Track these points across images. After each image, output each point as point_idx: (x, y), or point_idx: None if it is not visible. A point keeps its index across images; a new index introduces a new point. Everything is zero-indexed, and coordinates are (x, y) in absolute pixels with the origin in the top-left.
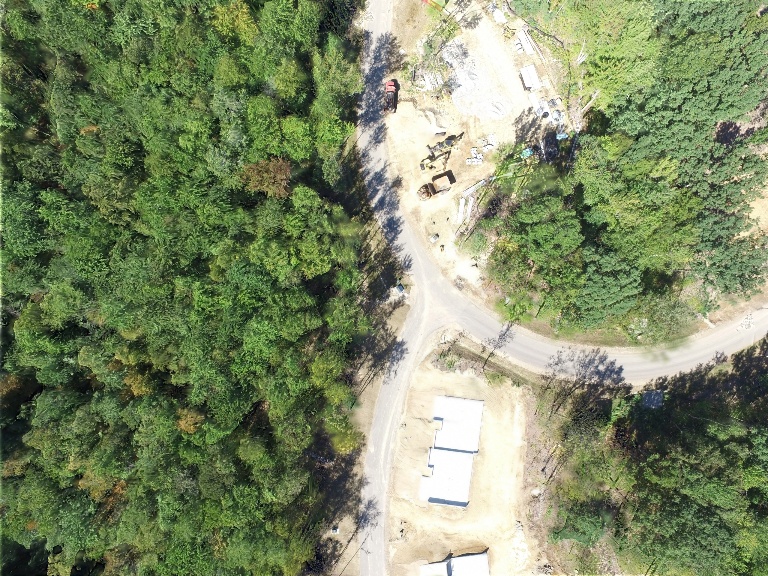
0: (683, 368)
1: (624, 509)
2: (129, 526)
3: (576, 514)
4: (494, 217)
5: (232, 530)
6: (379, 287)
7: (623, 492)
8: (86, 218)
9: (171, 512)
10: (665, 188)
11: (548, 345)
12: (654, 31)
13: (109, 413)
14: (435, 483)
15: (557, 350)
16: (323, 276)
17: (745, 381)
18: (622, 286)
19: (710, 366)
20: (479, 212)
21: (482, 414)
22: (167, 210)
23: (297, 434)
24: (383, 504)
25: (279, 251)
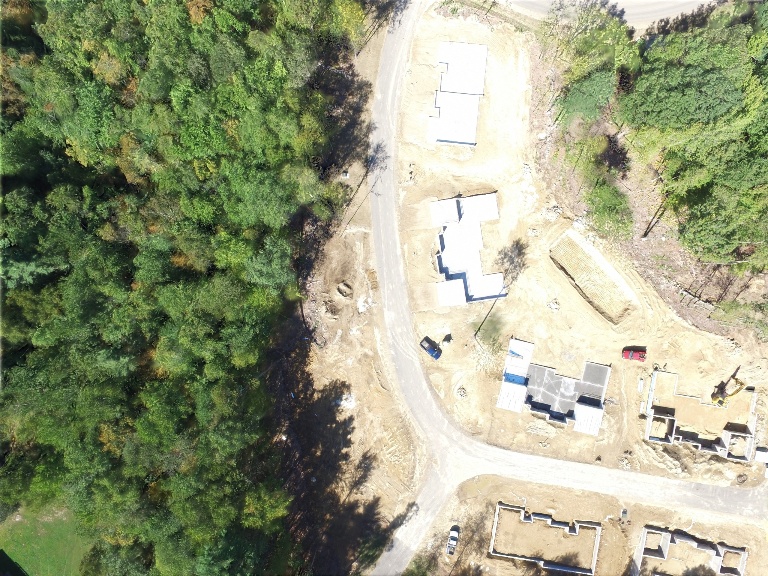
0: (685, 9)
1: (630, 154)
2: (143, 105)
3: (581, 82)
4: None
5: (244, 112)
6: None
7: (629, 137)
8: None
9: (184, 88)
10: None
11: None
12: None
13: (121, 11)
14: (442, 126)
15: None
16: None
17: None
18: None
19: (711, 7)
20: None
21: (486, 58)
22: None
23: None
24: (391, 148)
25: None
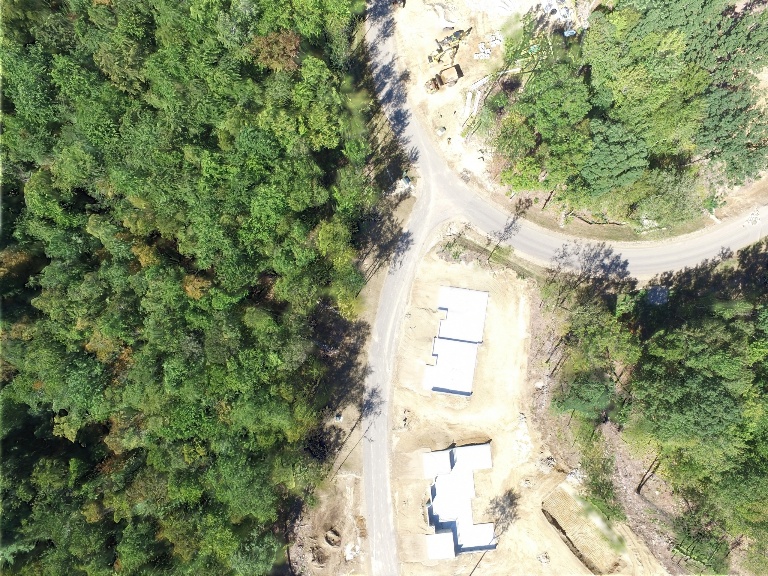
0: (689, 263)
1: None
2: (135, 387)
3: (580, 383)
4: (501, 111)
5: (237, 395)
6: (385, 179)
7: (627, 387)
8: (97, 87)
9: (177, 373)
10: (673, 62)
11: (553, 238)
12: None
13: (117, 280)
14: (439, 373)
15: (562, 243)
16: (330, 152)
17: (751, 278)
18: (629, 156)
19: (716, 262)
20: (486, 106)
21: (487, 305)
22: (177, 79)
23: (303, 294)
24: (387, 393)
25: (288, 117)
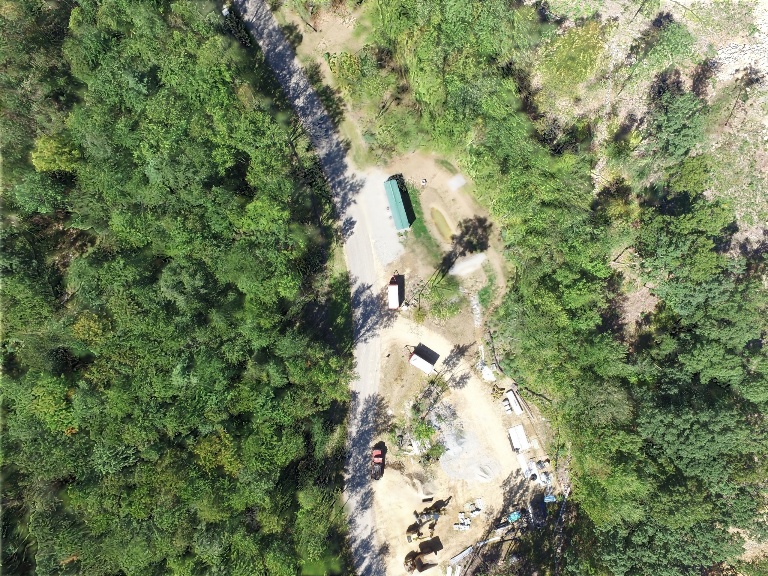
0: None
1: None
2: None
3: None
4: None
5: None
6: None
7: None
8: None
9: None
10: None
11: None
12: (642, 460)
13: None
14: None
15: None
16: None
17: None
18: None
19: None
20: None
21: None
22: None
23: None
24: None
25: None
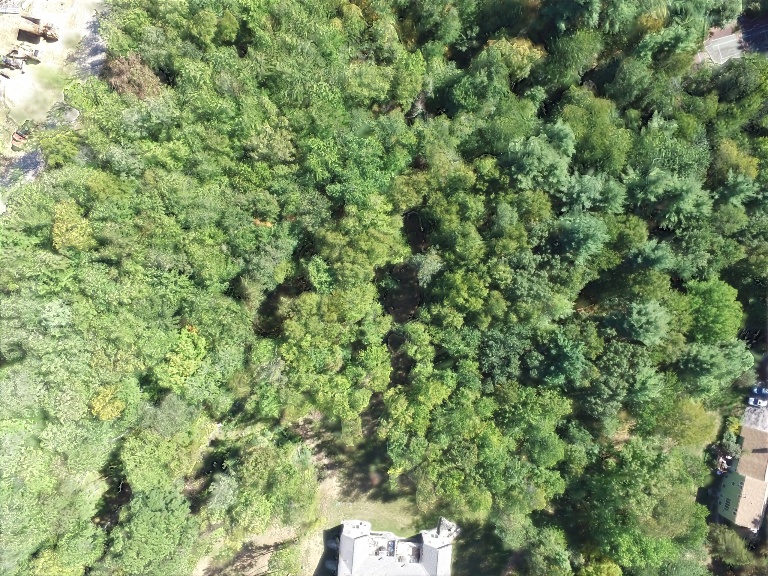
0: None
1: None
2: None
3: None
4: None
5: None
6: None
7: None
8: None
9: None
10: None
11: None
12: None
13: None
14: None
15: None
16: None
17: None
18: None
19: None
20: None
21: None
22: None
23: None
24: None
25: None
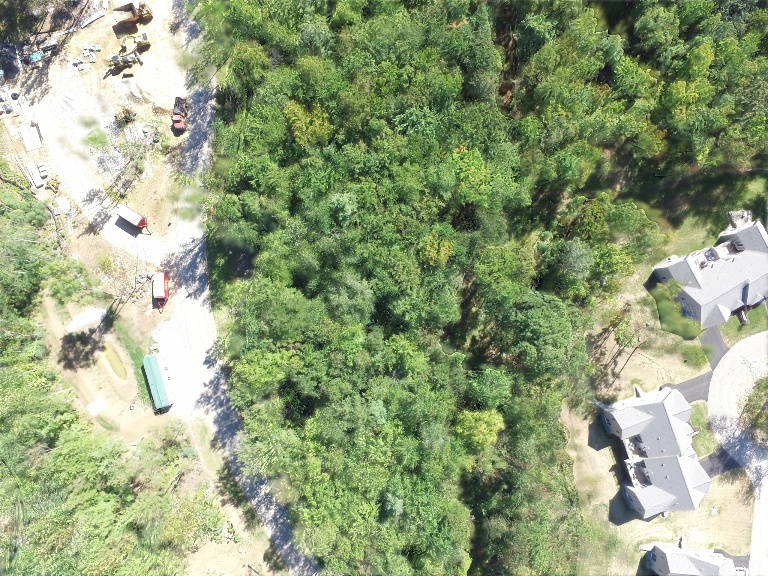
0: None
1: None
2: None
3: None
4: None
5: None
6: None
7: None
8: None
9: None
10: None
11: None
12: None
13: None
14: None
15: None
16: None
17: None
18: None
19: None
20: None
21: None
22: None
23: None
24: None
25: None
